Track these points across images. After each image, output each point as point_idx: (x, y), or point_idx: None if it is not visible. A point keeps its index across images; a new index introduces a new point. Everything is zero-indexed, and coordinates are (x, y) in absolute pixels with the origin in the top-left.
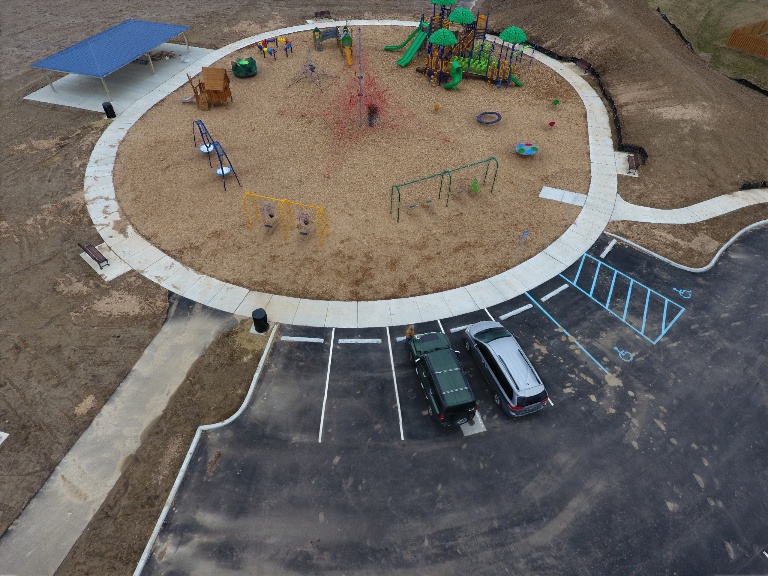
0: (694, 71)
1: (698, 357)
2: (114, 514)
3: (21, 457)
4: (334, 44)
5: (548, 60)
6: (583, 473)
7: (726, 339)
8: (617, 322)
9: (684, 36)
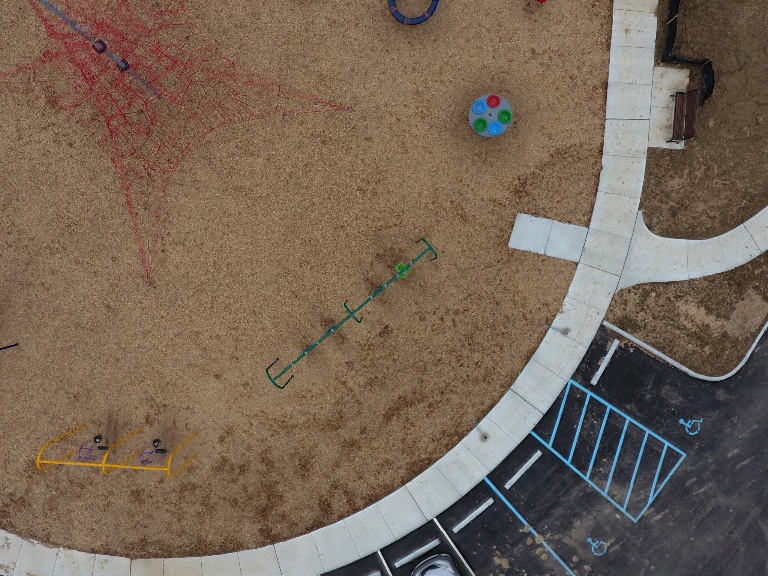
0: None
1: (682, 529)
2: None
3: None
4: None
5: None
6: None
7: (723, 493)
8: (597, 500)
9: None
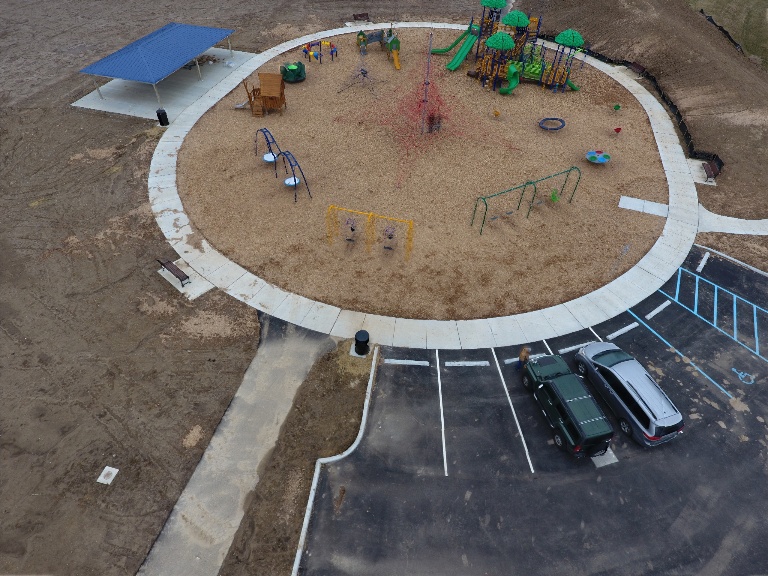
0: (754, 75)
1: None
2: (245, 558)
3: (136, 495)
4: (378, 47)
5: (598, 63)
6: (730, 508)
7: None
8: (729, 341)
9: (732, 38)
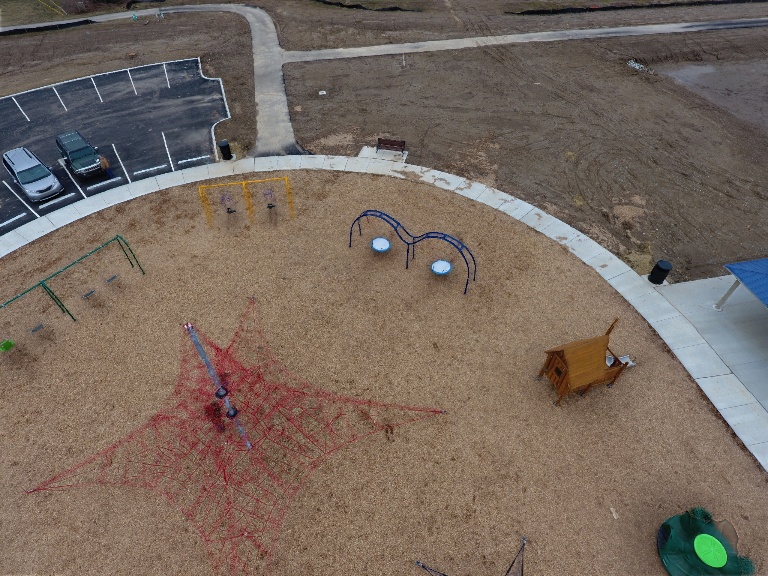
0: None
1: None
2: None
3: None
4: None
5: None
6: None
7: None
8: None
9: None
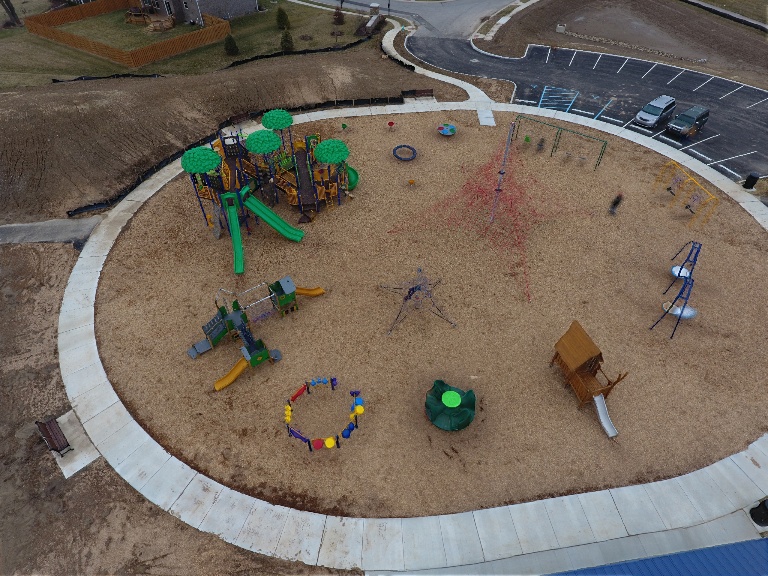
0: (260, 67)
1: (573, 84)
2: None
3: None
4: (233, 349)
5: None
6: None
7: None
8: None
9: None
